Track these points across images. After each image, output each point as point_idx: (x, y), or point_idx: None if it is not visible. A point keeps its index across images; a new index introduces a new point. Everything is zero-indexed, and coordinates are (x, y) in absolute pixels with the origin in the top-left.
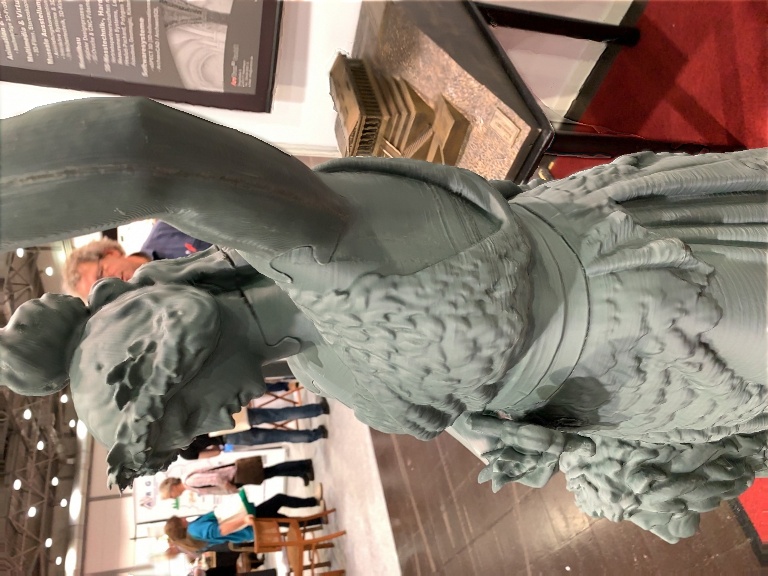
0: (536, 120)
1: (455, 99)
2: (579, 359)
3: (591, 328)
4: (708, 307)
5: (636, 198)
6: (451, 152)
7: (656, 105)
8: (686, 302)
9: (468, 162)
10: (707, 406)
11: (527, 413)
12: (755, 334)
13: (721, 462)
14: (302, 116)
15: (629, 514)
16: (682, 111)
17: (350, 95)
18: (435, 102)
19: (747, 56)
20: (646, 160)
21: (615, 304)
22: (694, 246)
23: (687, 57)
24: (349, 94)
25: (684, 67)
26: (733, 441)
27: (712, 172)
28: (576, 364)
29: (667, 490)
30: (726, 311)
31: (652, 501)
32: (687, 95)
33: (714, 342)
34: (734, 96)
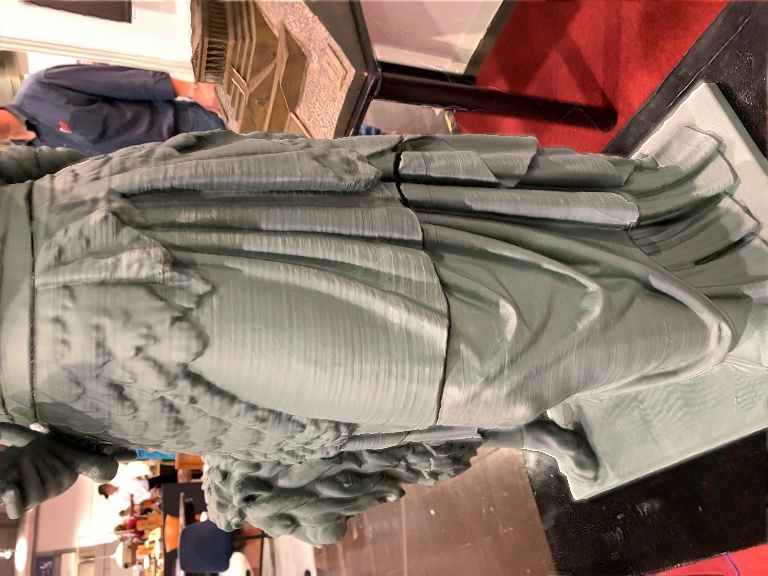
0: (365, 62)
1: (294, 29)
2: (33, 384)
3: (37, 350)
4: (186, 335)
5: (153, 191)
6: (291, 88)
7: (548, 54)
8: (155, 328)
9: (308, 101)
10: (248, 434)
11: (47, 427)
12: (249, 368)
13: (341, 478)
14: (176, 30)
15: (236, 525)
16: (569, 64)
17: (198, 12)
18: (279, 30)
19: (631, 10)
20: (219, 141)
21: (64, 324)
22: (204, 257)
23: (580, 4)
24: (198, 11)
25: (576, 15)
26: (358, 456)
27: (260, 166)
28: (33, 389)
29: (265, 506)
30: (214, 340)
31: (253, 515)
32: (575, 47)
33: (205, 373)
34: (614, 53)
